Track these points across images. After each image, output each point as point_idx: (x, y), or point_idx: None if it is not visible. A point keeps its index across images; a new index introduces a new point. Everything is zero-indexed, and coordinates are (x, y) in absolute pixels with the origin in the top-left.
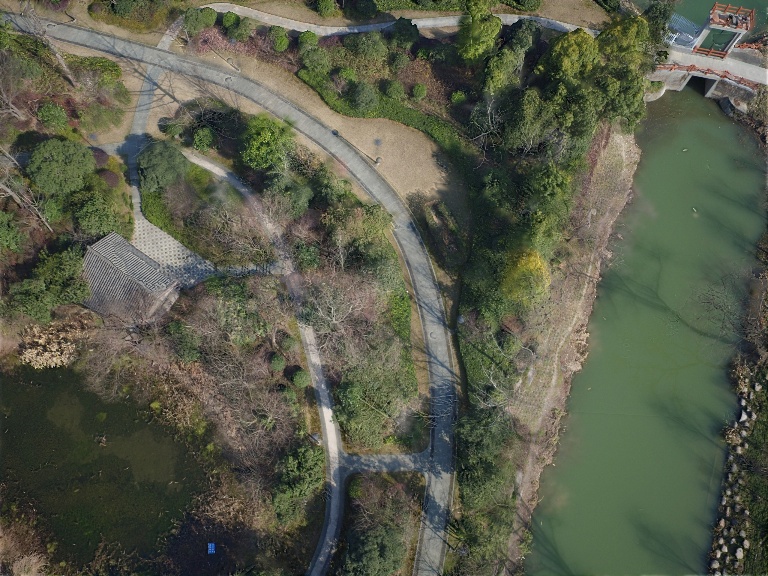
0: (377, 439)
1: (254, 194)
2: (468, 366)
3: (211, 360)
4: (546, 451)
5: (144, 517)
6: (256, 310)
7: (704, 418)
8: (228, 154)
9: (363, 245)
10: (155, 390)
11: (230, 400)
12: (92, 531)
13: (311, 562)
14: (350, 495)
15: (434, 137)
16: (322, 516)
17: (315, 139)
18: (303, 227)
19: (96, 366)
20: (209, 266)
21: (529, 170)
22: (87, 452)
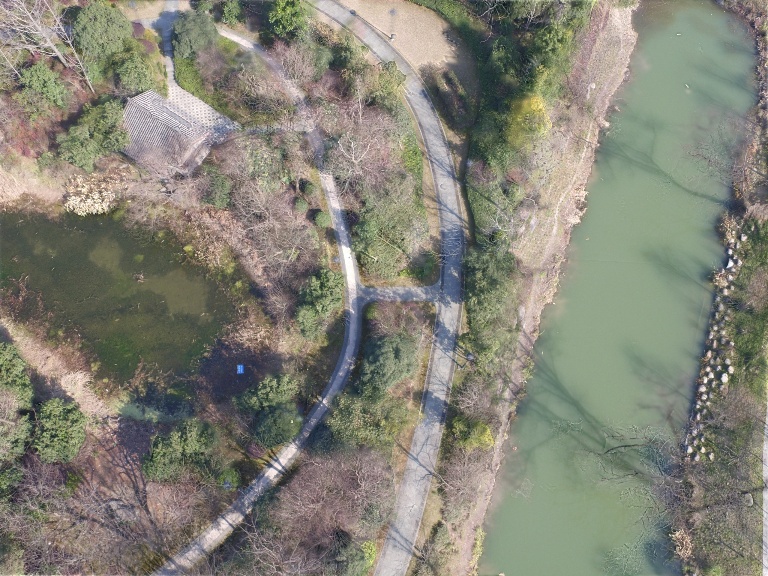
0: (392, 271)
1: (278, 63)
2: (475, 211)
3: (239, 207)
4: (547, 291)
5: (179, 343)
6: (281, 159)
7: (694, 265)
8: (254, 28)
9: (380, 96)
10: (188, 236)
11: (257, 242)
12: (132, 354)
13: (332, 376)
14: (367, 317)
15: (444, 14)
16: (342, 338)
17: (334, 18)
18: (324, 87)
19: (134, 214)
20: (237, 126)
21: (532, 41)
22: (126, 288)
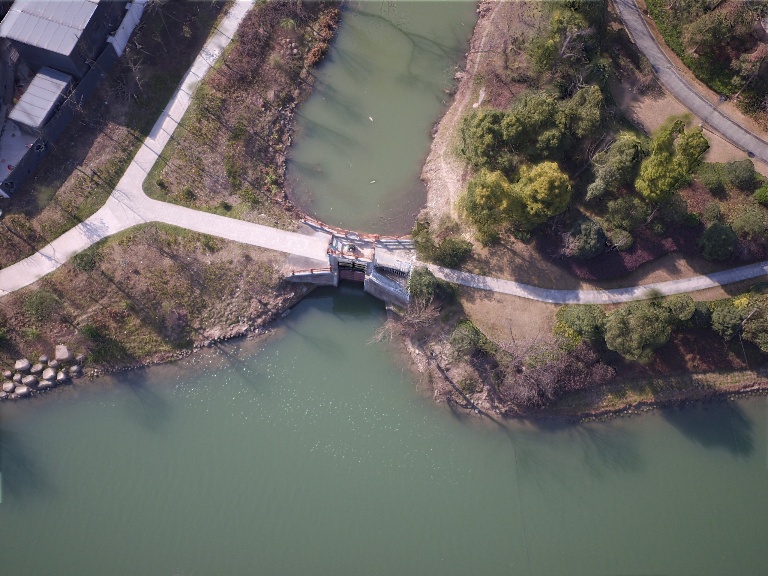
0: None
1: None
2: None
3: None
4: None
5: None
6: None
7: None
8: None
9: None
10: None
11: None
12: None
13: None
14: None
15: None
16: None
17: None
18: None
19: None
20: None
21: None
22: None
